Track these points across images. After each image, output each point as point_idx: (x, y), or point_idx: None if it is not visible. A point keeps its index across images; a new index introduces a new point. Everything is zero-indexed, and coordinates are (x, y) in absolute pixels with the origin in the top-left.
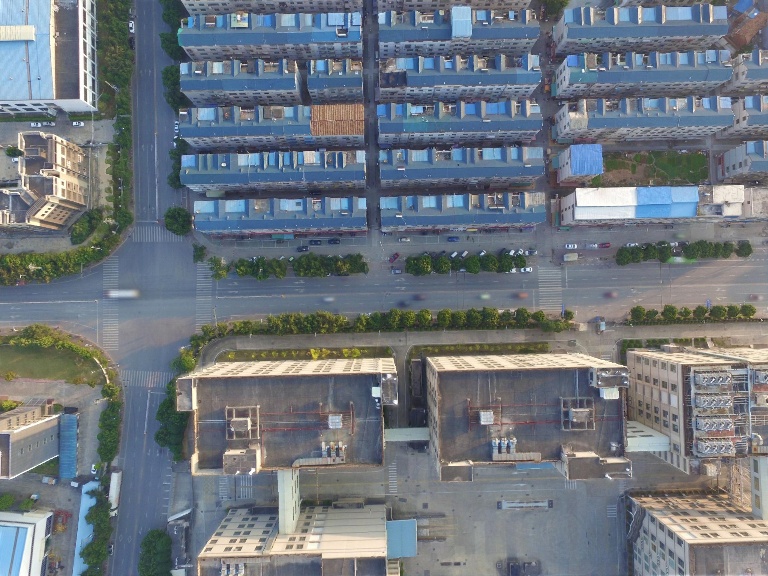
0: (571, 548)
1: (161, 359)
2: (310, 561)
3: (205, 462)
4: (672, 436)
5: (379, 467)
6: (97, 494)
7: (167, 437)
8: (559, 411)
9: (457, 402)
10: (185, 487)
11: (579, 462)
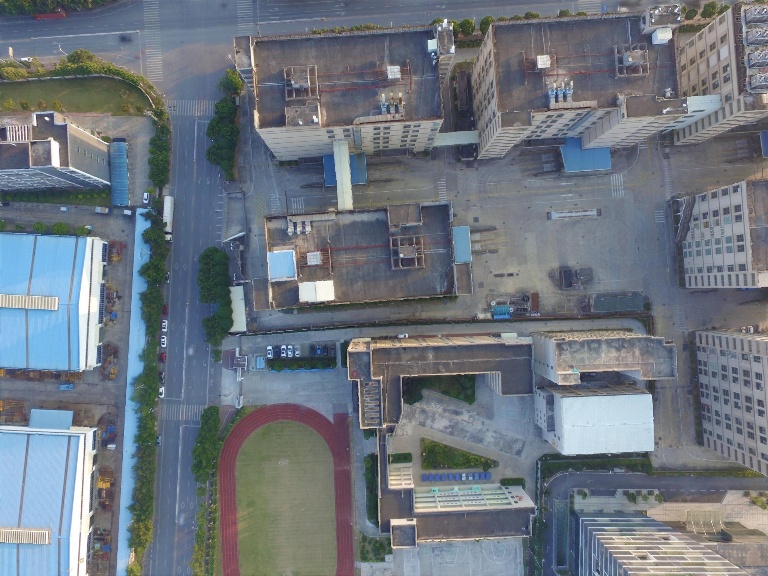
0: (621, 254)
1: (206, 88)
2: (375, 218)
3: (266, 125)
4: (723, 90)
5: (428, 184)
6: (152, 215)
7: (219, 151)
8: (613, 59)
9: (512, 55)
10: (237, 213)
11: (636, 100)
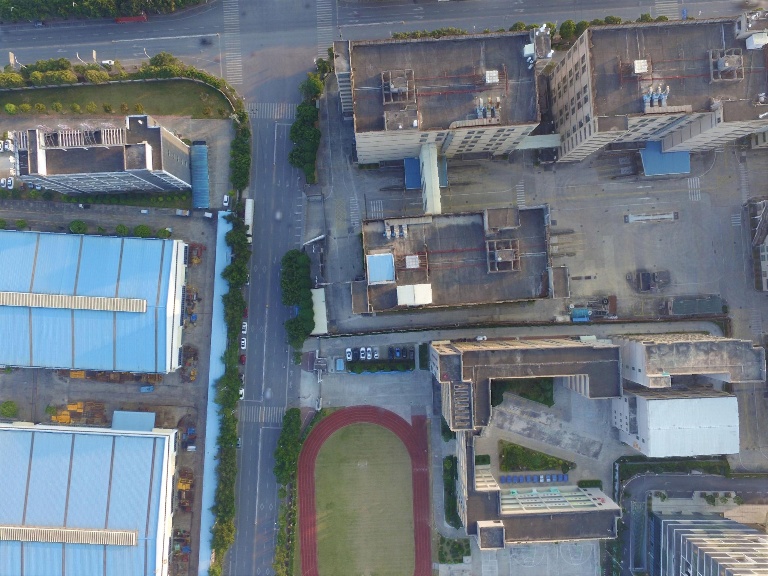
0: (698, 257)
1: (286, 91)
2: (471, 222)
3: (363, 129)
4: None
5: (507, 187)
6: (234, 218)
7: (302, 154)
8: (707, 64)
9: (607, 60)
10: (316, 215)
11: (733, 105)
